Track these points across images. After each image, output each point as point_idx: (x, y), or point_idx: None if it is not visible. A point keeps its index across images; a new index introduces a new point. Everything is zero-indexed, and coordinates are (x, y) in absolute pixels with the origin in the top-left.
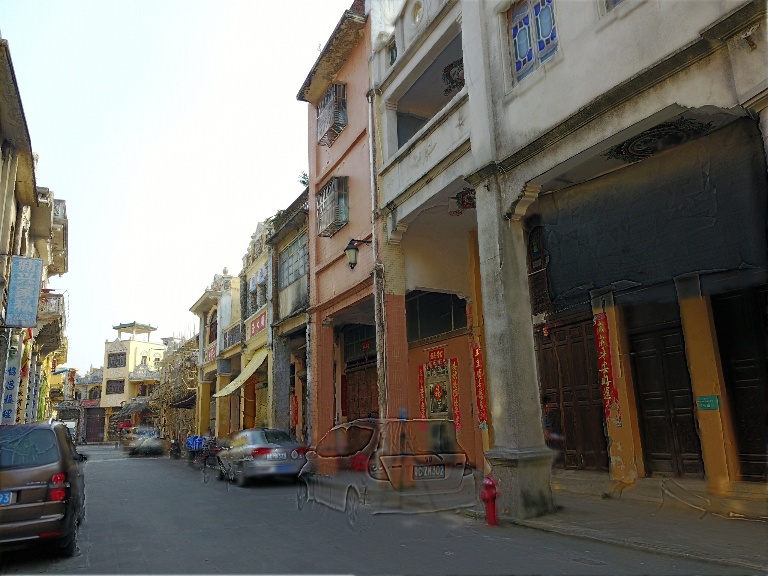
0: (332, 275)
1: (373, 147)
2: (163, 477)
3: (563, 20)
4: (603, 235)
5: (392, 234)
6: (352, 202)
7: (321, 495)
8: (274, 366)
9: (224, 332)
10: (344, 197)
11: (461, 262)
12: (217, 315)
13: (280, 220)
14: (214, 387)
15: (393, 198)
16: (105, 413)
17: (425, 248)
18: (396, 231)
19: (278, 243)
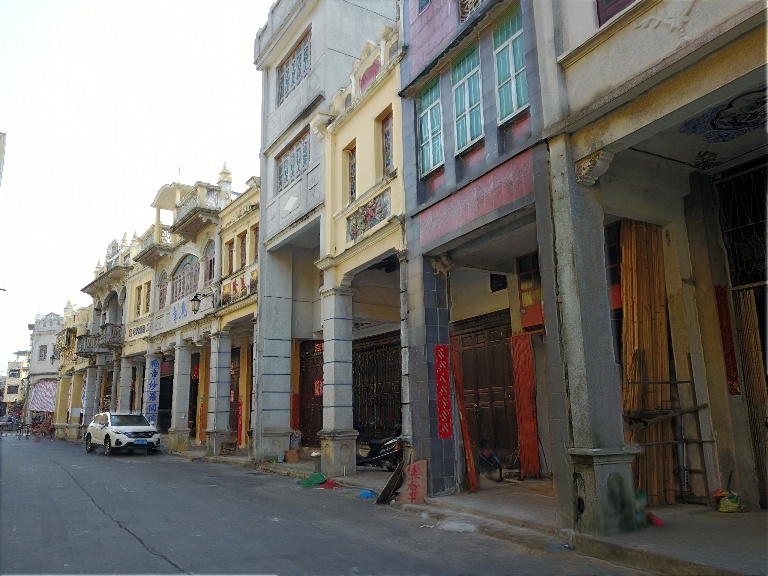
0: None
1: None
2: None
3: None
4: None
5: None
6: None
7: None
8: None
9: None
10: None
11: None
12: None
13: None
14: None
15: None
16: (7, 405)
17: None
18: None
19: None
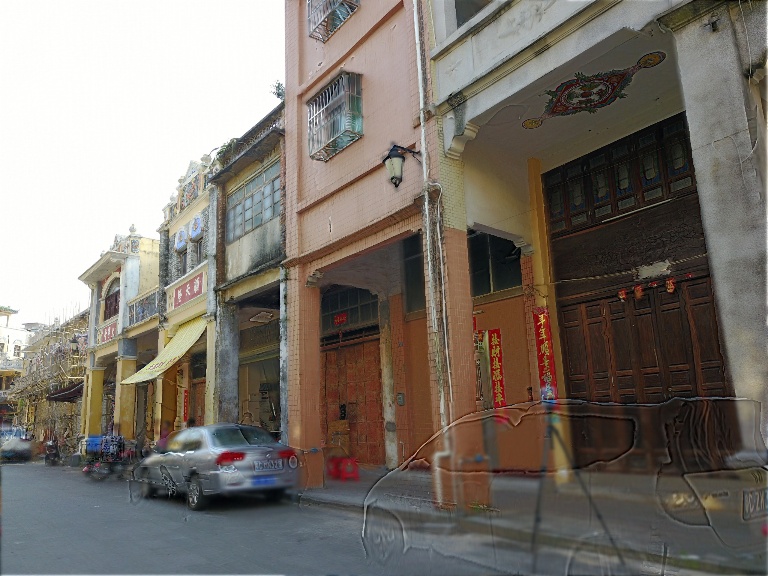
0: (329, 212)
1: (419, 22)
2: (55, 494)
3: None
4: None
5: (453, 141)
6: (370, 108)
7: (454, 542)
8: (218, 342)
9: (129, 304)
10: (357, 101)
11: (520, 198)
12: (120, 283)
13: (231, 151)
14: (108, 375)
15: (463, 86)
16: None
17: (484, 171)
18: (461, 137)
19: (227, 181)
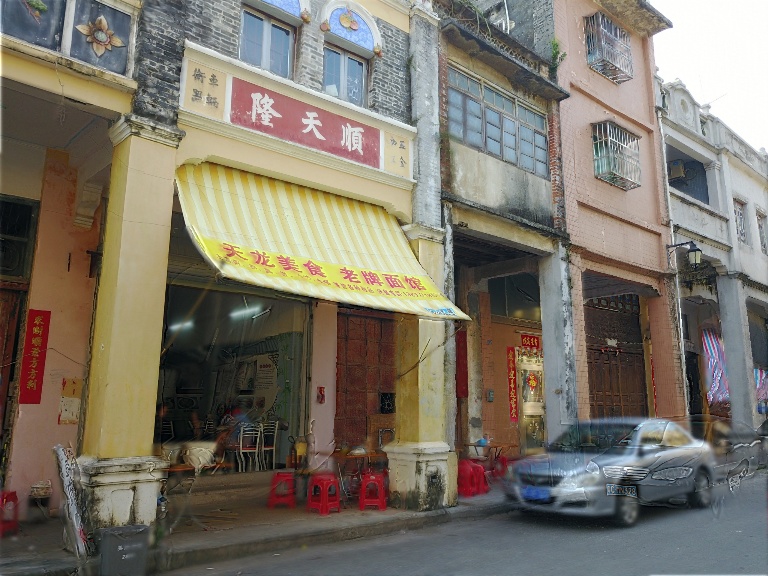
0: (602, 227)
1: None
2: None
3: (753, 237)
4: (751, 336)
5: None
6: None
7: None
8: None
9: None
10: None
11: None
12: None
13: None
14: None
15: None
16: None
17: None
18: None
19: (454, 44)
